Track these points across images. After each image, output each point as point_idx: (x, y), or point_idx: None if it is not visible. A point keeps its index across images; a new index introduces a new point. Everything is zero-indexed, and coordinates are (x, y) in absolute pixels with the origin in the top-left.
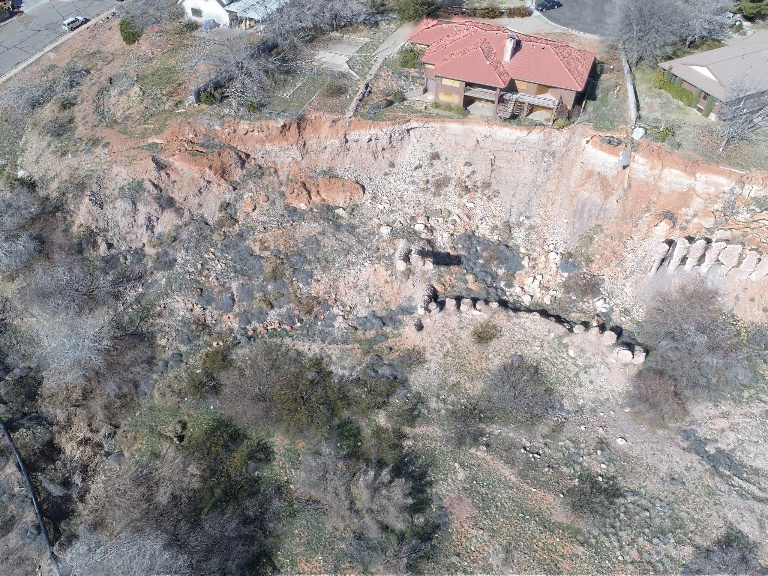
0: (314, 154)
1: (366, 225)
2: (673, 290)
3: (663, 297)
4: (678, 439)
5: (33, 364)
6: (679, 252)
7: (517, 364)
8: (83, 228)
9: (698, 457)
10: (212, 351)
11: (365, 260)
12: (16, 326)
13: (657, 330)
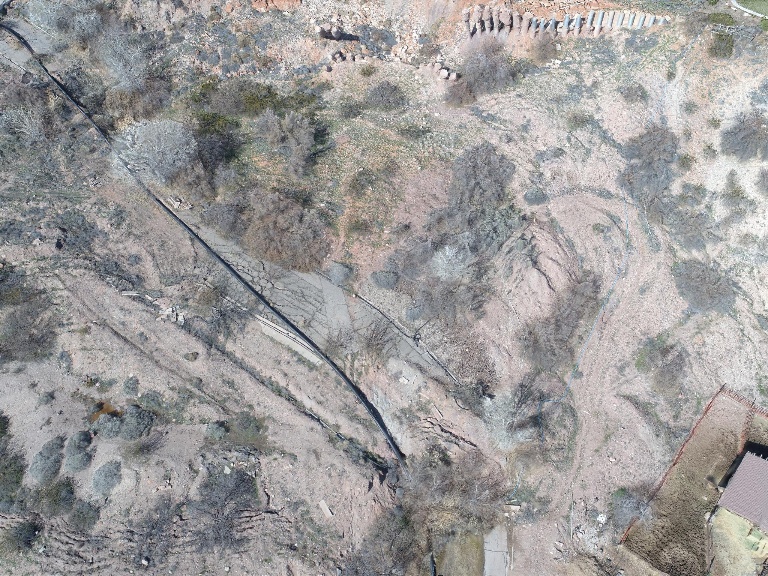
0: None
1: (301, 19)
2: (480, 46)
3: (474, 51)
4: (468, 111)
5: (98, 93)
6: (476, 15)
7: (385, 86)
8: (127, 16)
9: (476, 117)
10: None
11: (299, 36)
12: (87, 73)
13: None
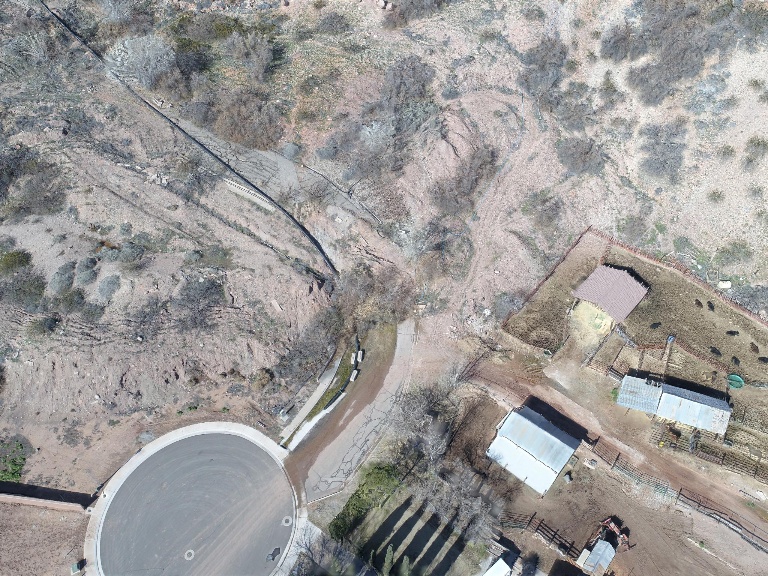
0: None
1: None
2: None
3: None
4: (400, 32)
5: (92, 27)
6: None
7: (334, 16)
8: None
9: (407, 36)
10: None
11: None
12: (82, 10)
13: None
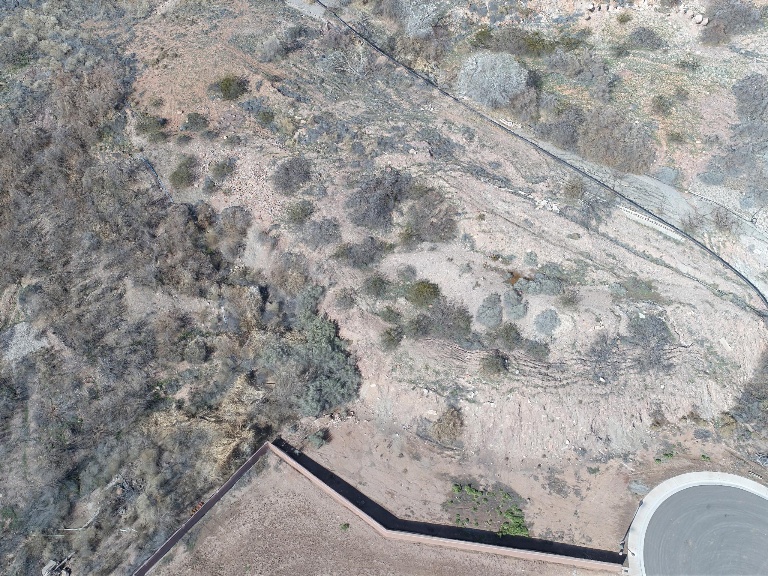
0: None
1: None
2: None
3: (715, 0)
4: (727, 49)
5: (385, 41)
6: None
7: (642, 31)
8: None
9: (737, 53)
10: (480, 32)
11: None
12: (373, 24)
13: (713, 11)
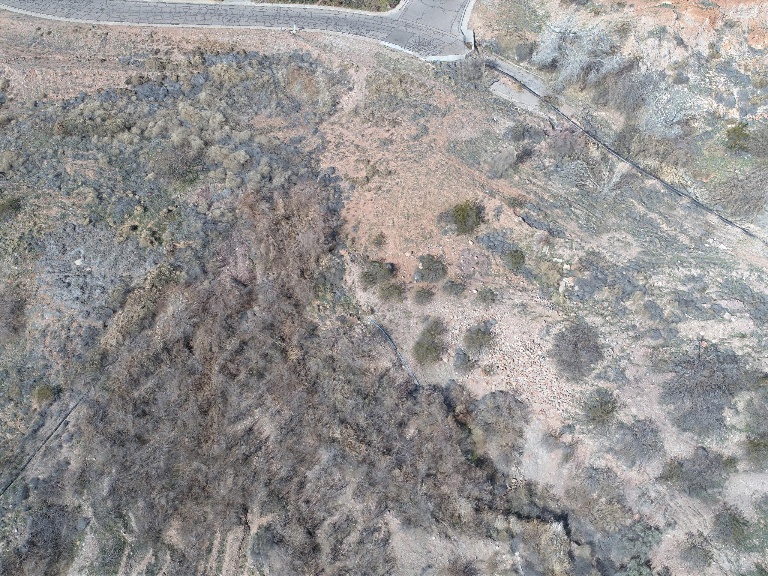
0: (764, 13)
1: None
2: None
3: None
4: None
5: (613, 138)
6: None
7: None
8: (632, 55)
9: None
10: (731, 129)
11: None
12: (596, 116)
13: None
